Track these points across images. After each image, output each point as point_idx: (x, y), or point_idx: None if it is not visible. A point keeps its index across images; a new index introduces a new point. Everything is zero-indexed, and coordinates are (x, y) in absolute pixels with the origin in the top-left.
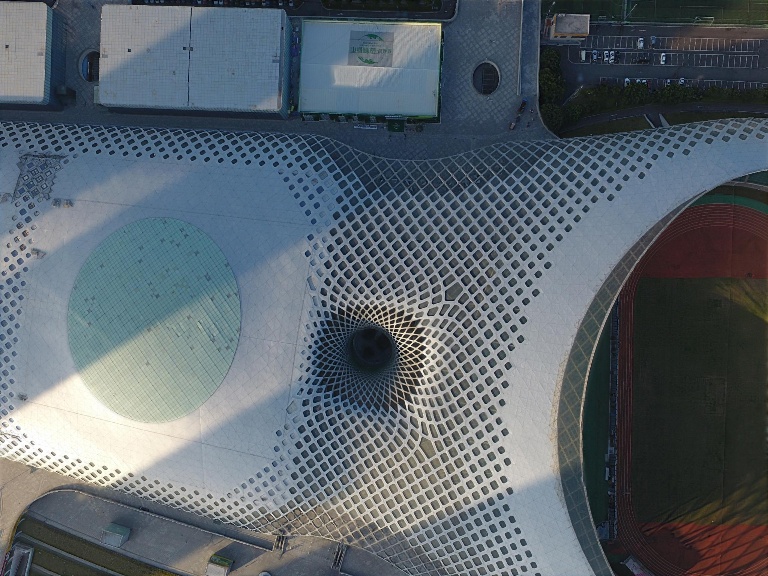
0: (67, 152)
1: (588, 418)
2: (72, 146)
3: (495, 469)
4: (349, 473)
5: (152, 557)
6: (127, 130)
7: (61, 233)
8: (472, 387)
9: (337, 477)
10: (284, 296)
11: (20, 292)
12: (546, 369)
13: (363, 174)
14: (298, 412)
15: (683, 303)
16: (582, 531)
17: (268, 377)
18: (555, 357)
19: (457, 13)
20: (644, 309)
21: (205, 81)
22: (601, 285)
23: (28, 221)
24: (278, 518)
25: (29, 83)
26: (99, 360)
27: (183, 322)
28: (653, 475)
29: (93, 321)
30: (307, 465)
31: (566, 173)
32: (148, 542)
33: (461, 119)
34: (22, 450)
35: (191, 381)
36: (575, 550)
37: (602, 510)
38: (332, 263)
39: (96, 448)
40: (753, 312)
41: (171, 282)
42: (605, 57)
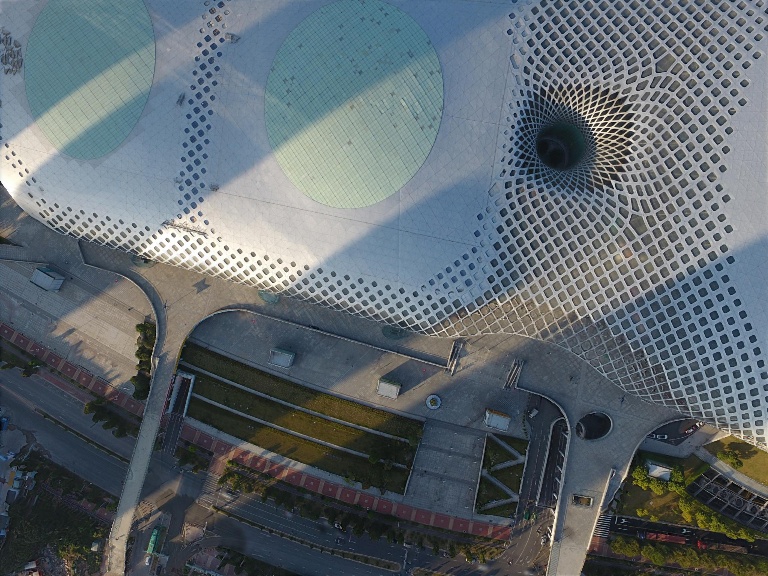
0: None
1: None
2: None
3: (714, 239)
4: (551, 258)
5: (317, 382)
6: None
7: (255, 17)
8: (689, 156)
9: (539, 263)
10: (487, 75)
11: (214, 77)
12: None
13: None
14: (500, 194)
15: None
16: None
17: (470, 158)
18: None
19: None
20: None
21: None
22: None
23: (221, 6)
24: (472, 312)
25: None
26: (298, 142)
27: (387, 99)
28: None
29: (293, 101)
30: (508, 251)
31: None
32: (313, 367)
33: None
34: (206, 250)
35: (393, 161)
36: None
37: None
38: (535, 41)
39: (287, 241)
40: None
41: (374, 58)
42: None
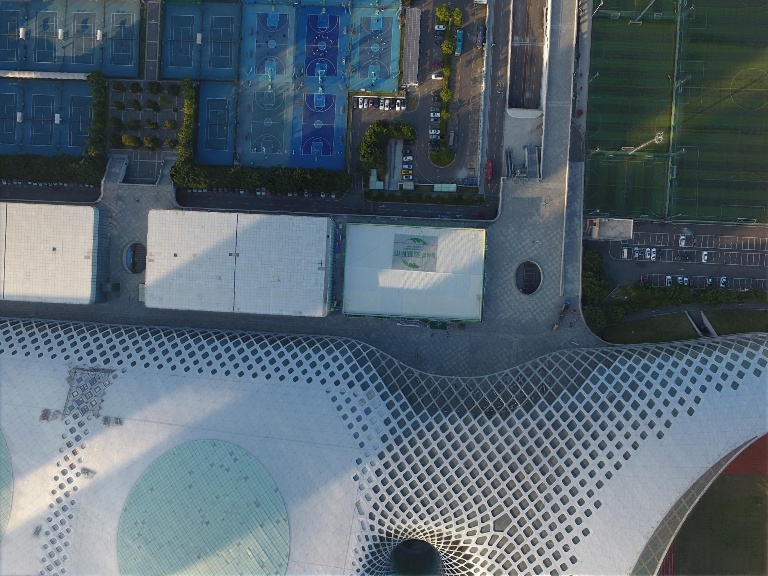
0: (116, 366)
1: None
2: (120, 358)
3: None
4: None
5: None
6: (174, 337)
7: None
8: None
9: None
10: (332, 520)
11: (70, 511)
12: None
13: (410, 393)
14: None
15: (724, 499)
16: None
17: None
18: None
19: (500, 213)
20: None
21: (251, 287)
22: (652, 532)
23: (78, 439)
24: None
25: (76, 285)
26: None
27: (233, 549)
28: None
29: (143, 545)
30: None
31: (614, 401)
32: None
33: (503, 318)
34: None
35: None
36: None
37: None
38: (380, 487)
39: None
40: None
41: (221, 509)
42: (647, 254)
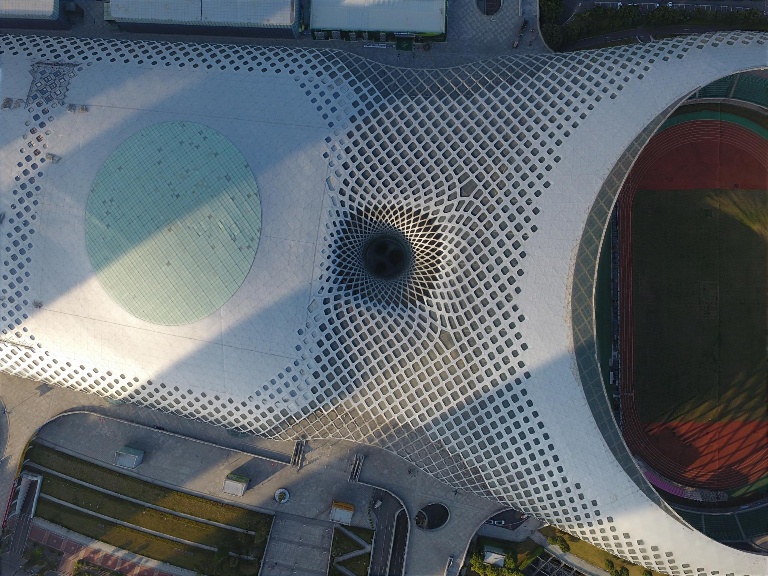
0: (81, 60)
1: None
2: (85, 55)
3: (512, 355)
4: (370, 370)
5: (166, 479)
6: (140, 42)
7: None
8: (489, 277)
9: (358, 374)
10: (304, 196)
11: (35, 197)
12: (559, 255)
13: (377, 81)
14: (319, 310)
15: (677, 213)
16: (597, 407)
17: (289, 276)
18: (567, 243)
19: None
20: (641, 220)
21: None
22: (608, 174)
23: (42, 126)
24: (299, 420)
25: None
26: (118, 262)
27: (204, 221)
28: (654, 377)
29: (112, 223)
30: (328, 363)
31: (570, 77)
32: (162, 464)
33: (466, 38)
34: (35, 363)
35: (212, 281)
36: (590, 427)
37: None
38: (350, 164)
39: (114, 355)
40: (740, 220)
41: (191, 182)
42: None
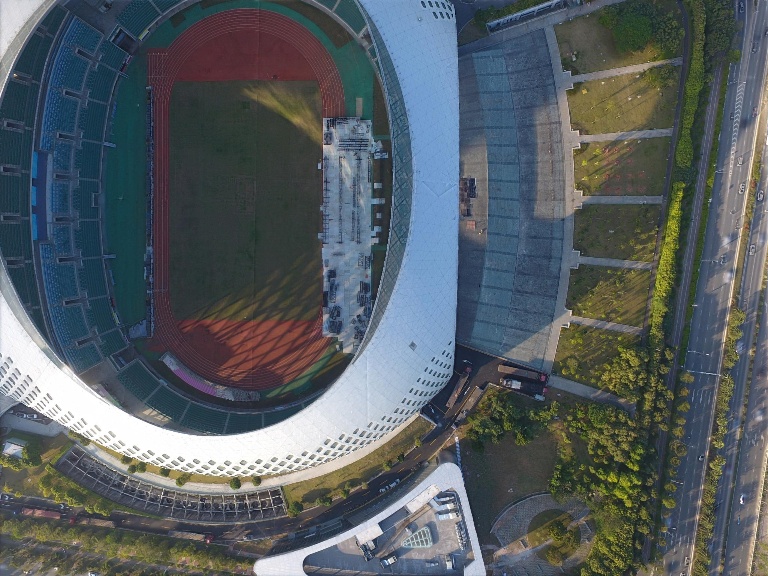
0: None
1: (127, 219)
2: None
3: None
4: None
5: None
6: None
7: None
8: None
9: None
10: None
11: None
12: None
13: None
14: None
15: (214, 106)
16: None
17: None
18: None
19: None
20: (178, 112)
21: None
22: (15, 37)
23: None
24: None
25: None
26: None
27: None
28: (189, 274)
29: None
30: None
31: None
32: None
33: None
34: None
35: None
36: None
37: (141, 309)
38: None
39: None
40: (278, 113)
41: None
42: None
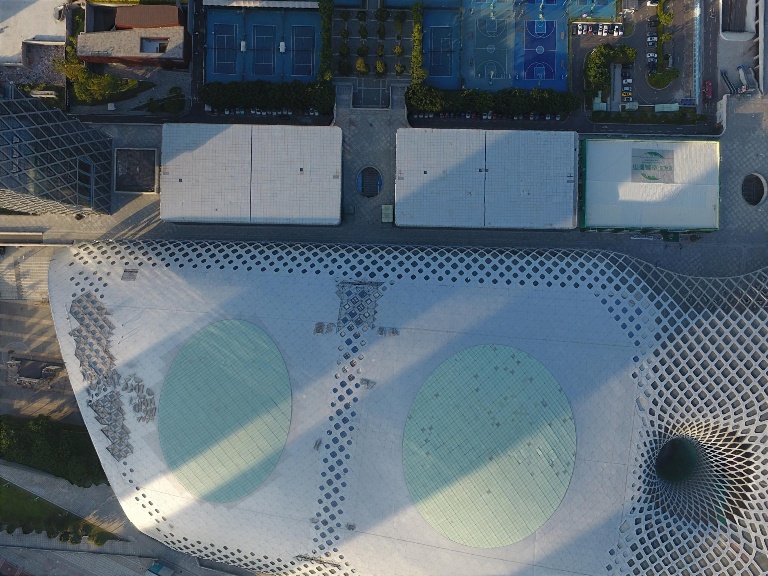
0: (383, 278)
1: None
2: (385, 272)
3: None
4: None
5: None
6: (431, 252)
7: (390, 362)
8: None
9: None
10: (615, 418)
11: (350, 423)
12: None
13: (674, 294)
14: (631, 531)
15: None
16: None
17: (602, 498)
18: None
19: (725, 129)
20: None
21: (501, 201)
22: None
23: (355, 351)
24: None
25: (325, 205)
26: (437, 489)
27: (524, 449)
28: None
29: (432, 451)
30: None
31: None
32: None
33: (732, 228)
34: None
35: (530, 506)
36: None
37: None
38: (658, 383)
39: (422, 574)
40: None
41: (510, 410)
42: None
